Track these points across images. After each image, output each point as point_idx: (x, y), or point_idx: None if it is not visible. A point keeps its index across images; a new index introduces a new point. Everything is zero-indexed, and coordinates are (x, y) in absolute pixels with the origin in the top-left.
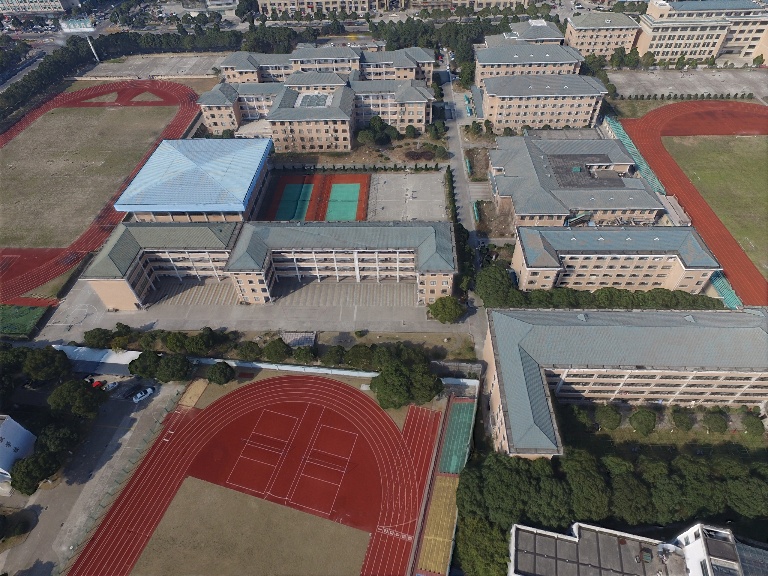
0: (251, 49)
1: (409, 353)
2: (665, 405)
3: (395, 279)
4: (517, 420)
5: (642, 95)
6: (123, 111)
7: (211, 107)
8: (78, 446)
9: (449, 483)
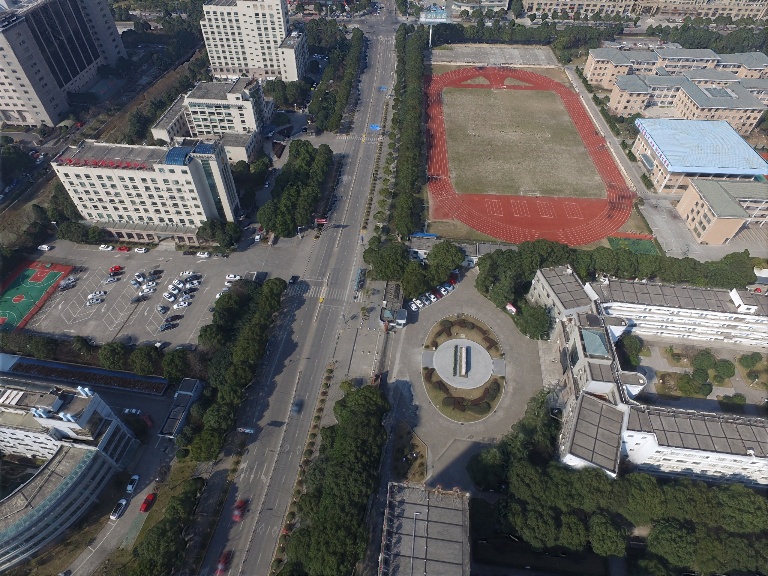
0: (568, 44)
1: None
2: None
3: None
4: None
5: None
6: (511, 93)
7: (633, 94)
8: None
9: None
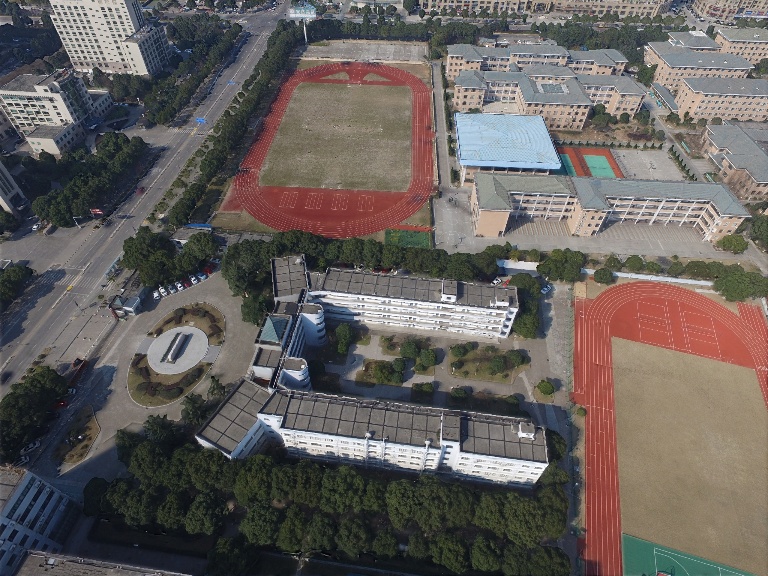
0: (443, 41)
1: (734, 267)
2: None
3: (677, 224)
4: None
5: None
6: (364, 88)
7: (468, 89)
8: None
9: None
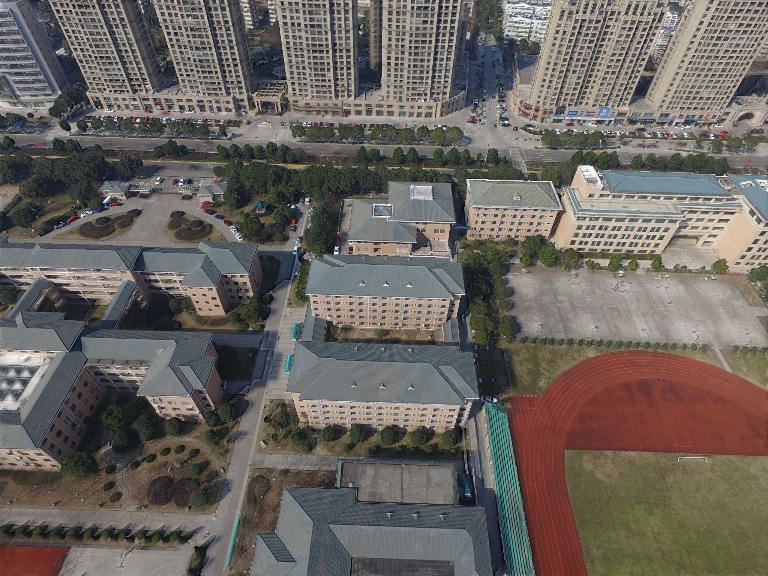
0: (31, 192)
1: None
2: None
3: None
4: None
5: (551, 340)
6: None
7: None
8: None
9: None
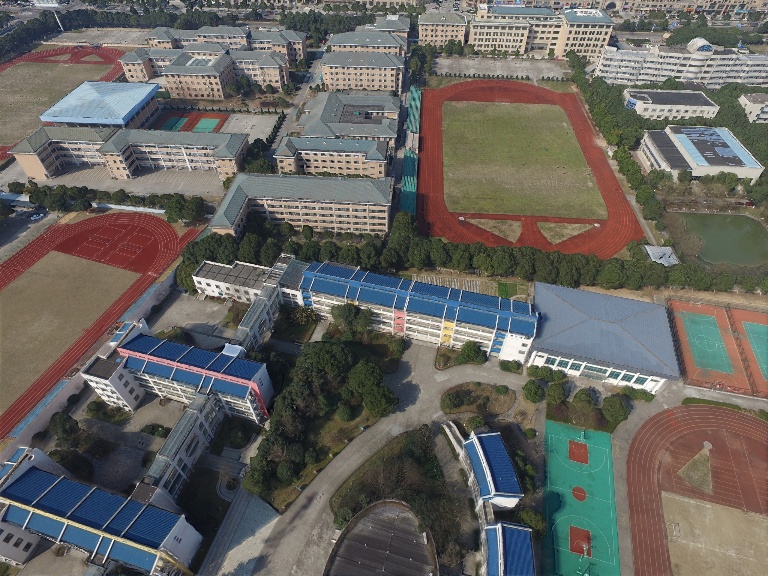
0: None
1: (193, 198)
2: (334, 232)
3: (214, 170)
4: (218, 214)
5: (450, 73)
6: (72, 67)
7: (128, 64)
8: None
9: None
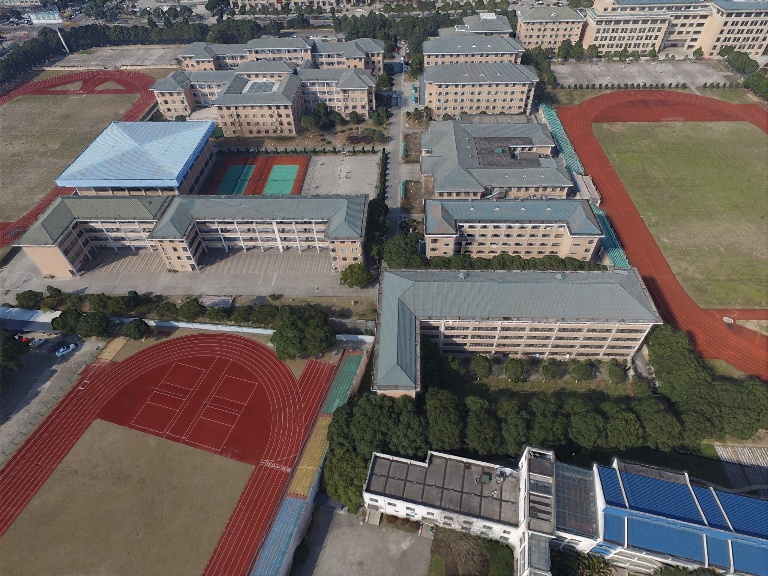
0: (215, 41)
1: (310, 311)
2: (542, 359)
3: (316, 250)
4: (384, 362)
5: (581, 85)
6: (85, 98)
7: (163, 93)
8: (0, 393)
9: (328, 422)
